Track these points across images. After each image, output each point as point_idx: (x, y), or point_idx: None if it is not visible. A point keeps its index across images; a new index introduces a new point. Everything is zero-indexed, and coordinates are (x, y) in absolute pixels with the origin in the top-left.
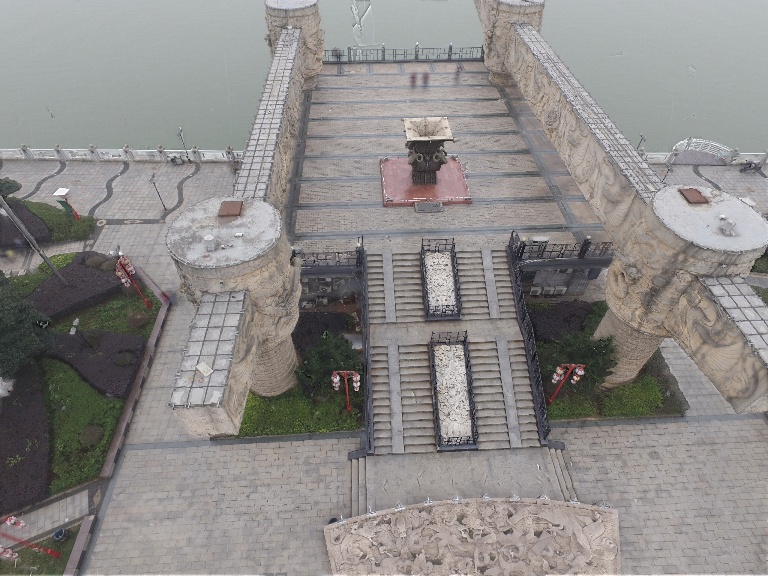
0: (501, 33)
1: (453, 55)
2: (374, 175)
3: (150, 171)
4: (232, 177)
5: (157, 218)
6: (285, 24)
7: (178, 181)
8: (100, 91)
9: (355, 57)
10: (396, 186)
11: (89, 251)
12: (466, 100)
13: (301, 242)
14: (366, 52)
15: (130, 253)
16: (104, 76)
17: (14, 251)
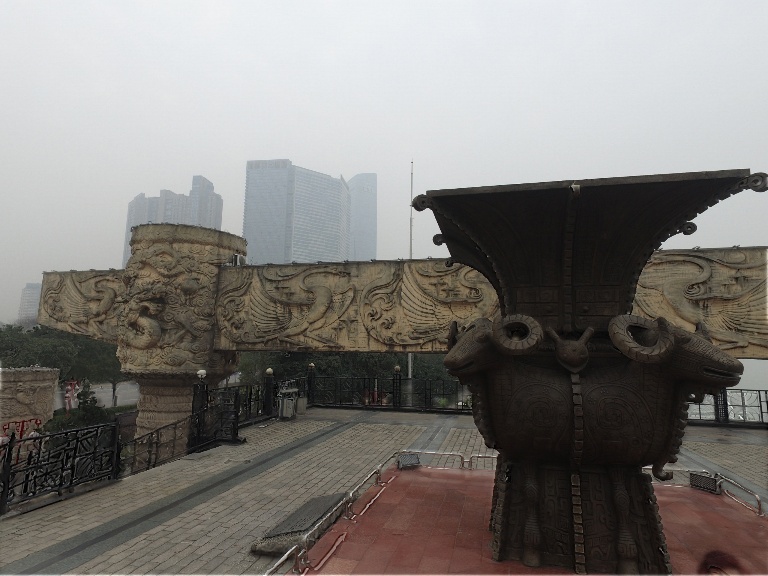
0: None
1: None
2: None
3: None
4: None
5: None
6: None
7: None
8: None
9: None
10: None
11: None
12: None
13: (329, 423)
14: None
15: None
16: None
17: None
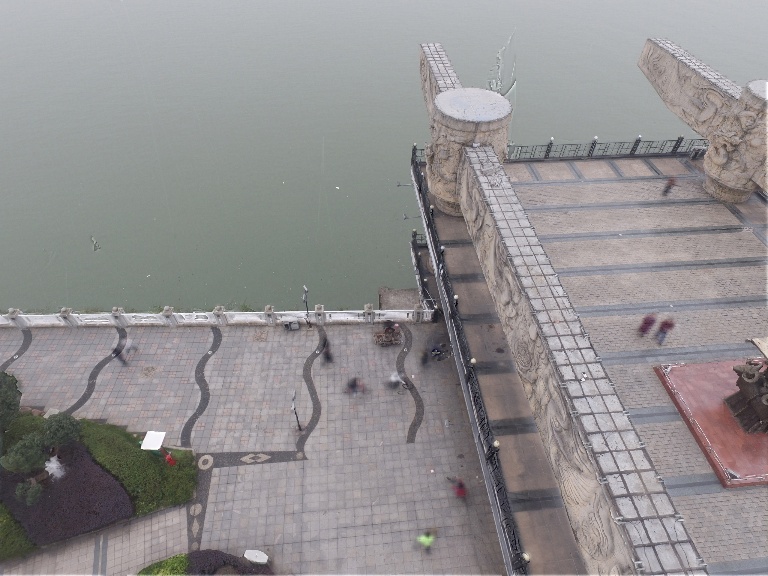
0: (761, 142)
1: (638, 150)
2: (664, 404)
3: (255, 344)
4: (378, 353)
5: (291, 448)
6: (470, 140)
7: (301, 364)
8: (169, 216)
9: (510, 155)
10: (721, 437)
11: (208, 551)
12: (699, 231)
13: None
14: (526, 149)
15: (268, 536)
16: (176, 197)
17: (74, 541)
